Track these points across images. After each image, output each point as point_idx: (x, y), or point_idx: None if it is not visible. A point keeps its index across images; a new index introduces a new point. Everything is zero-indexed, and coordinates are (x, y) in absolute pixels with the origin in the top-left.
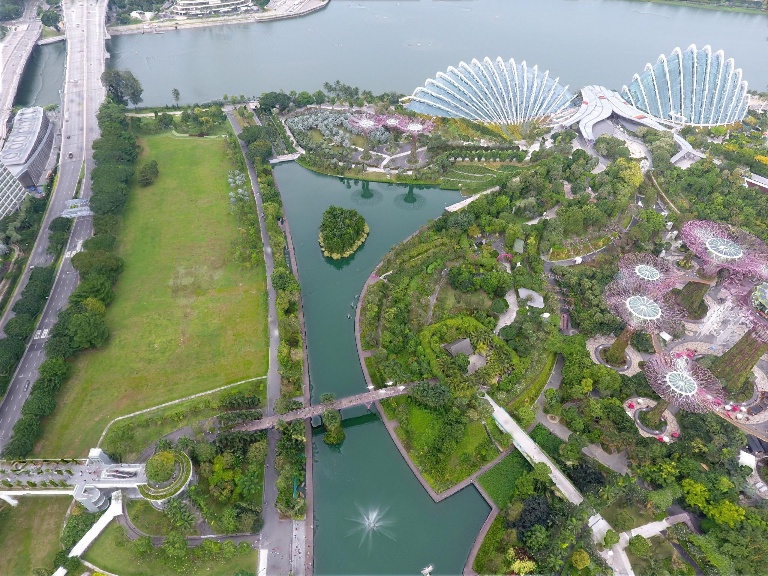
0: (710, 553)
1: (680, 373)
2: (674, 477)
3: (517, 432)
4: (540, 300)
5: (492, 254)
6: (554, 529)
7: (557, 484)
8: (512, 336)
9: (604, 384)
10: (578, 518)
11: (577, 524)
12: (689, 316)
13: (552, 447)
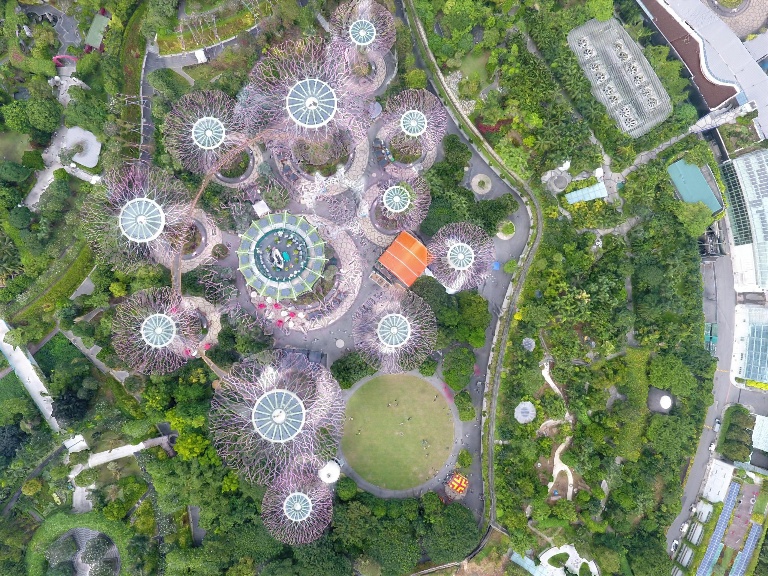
0: (154, 482)
1: (162, 317)
2: (161, 407)
3: (17, 351)
4: (95, 151)
5: (42, 54)
6: (13, 461)
7: (46, 408)
8: (22, 225)
9: (135, 291)
10: (16, 465)
11: (15, 469)
12: (315, 171)
13: (66, 360)
